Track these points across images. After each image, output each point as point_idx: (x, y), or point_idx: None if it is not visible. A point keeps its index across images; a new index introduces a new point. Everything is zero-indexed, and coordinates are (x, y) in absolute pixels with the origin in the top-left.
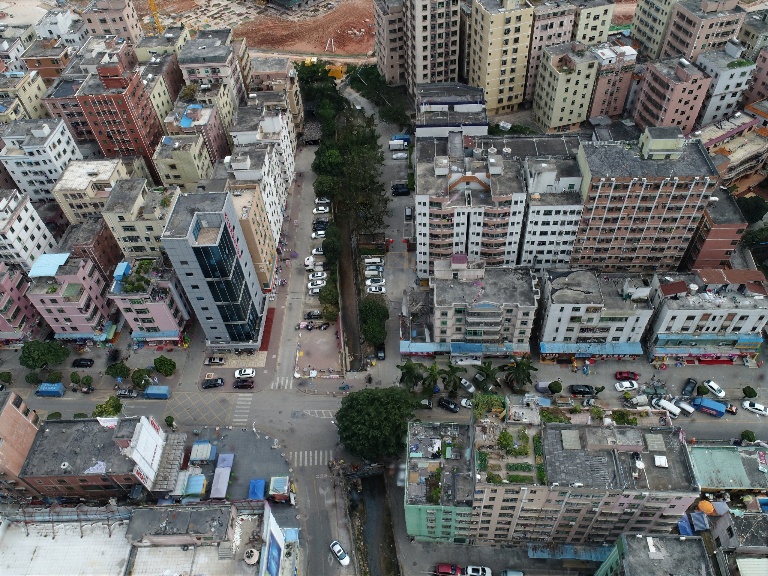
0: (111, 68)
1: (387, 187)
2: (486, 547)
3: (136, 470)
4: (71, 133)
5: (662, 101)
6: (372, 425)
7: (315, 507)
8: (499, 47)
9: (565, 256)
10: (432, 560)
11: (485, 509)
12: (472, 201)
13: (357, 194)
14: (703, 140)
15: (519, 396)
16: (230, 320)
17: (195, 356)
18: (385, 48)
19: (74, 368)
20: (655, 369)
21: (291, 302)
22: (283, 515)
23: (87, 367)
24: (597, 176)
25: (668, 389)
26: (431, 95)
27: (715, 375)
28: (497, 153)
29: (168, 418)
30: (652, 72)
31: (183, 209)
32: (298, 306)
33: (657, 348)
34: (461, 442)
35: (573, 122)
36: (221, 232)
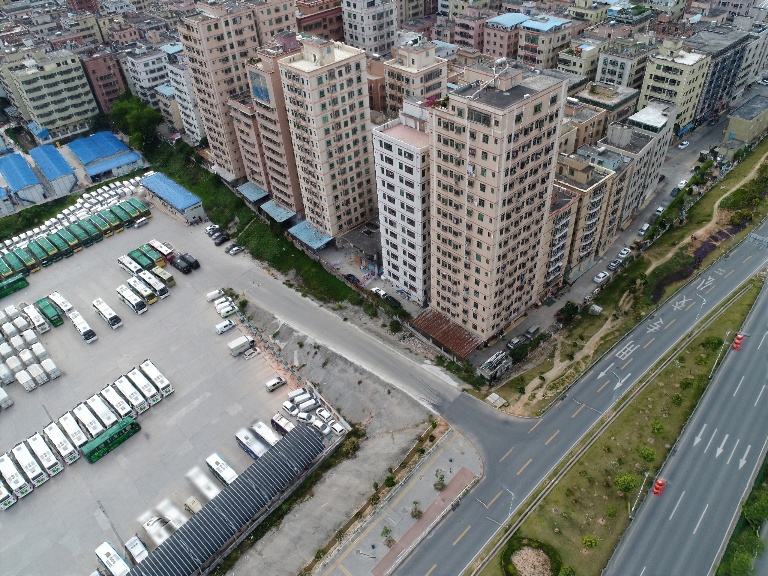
0: None
1: None
2: None
3: None
4: None
5: None
6: None
7: None
8: None
9: None
10: None
11: None
12: None
13: None
14: None
15: None
16: None
17: None
18: None
19: None
20: None
21: None
22: None
23: None
24: None
25: None
26: None
27: None
28: None
29: None
30: None
31: None
32: None
33: None
34: None
35: None
36: None
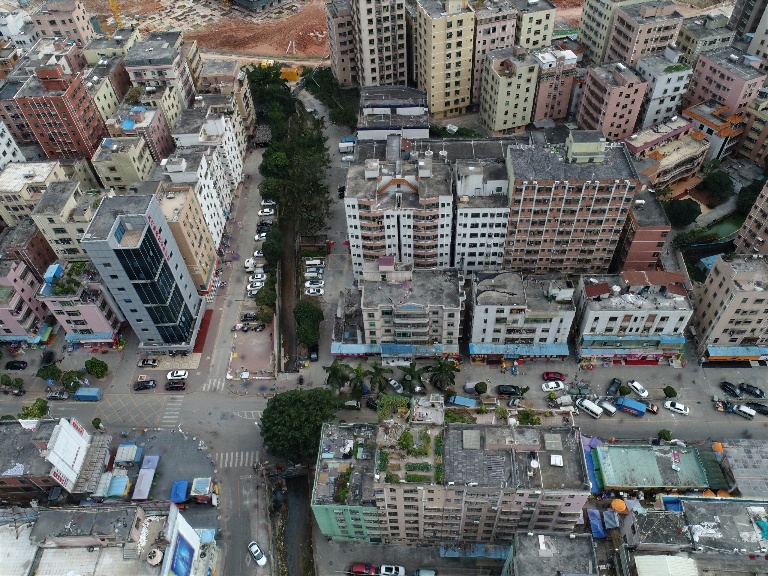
0: (50, 70)
1: (334, 189)
2: (402, 546)
3: (53, 472)
4: (17, 135)
5: (601, 105)
6: (293, 426)
7: (237, 508)
8: (442, 51)
9: (497, 258)
10: (348, 560)
11: (390, 508)
12: (402, 204)
13: (300, 196)
14: (639, 143)
15: (446, 397)
16: (161, 322)
17: (129, 358)
18: (336, 51)
19: (7, 370)
20: (582, 369)
21: (229, 304)
22: (204, 516)
23: (20, 369)
24: (521, 179)
25: (593, 389)
26: (375, 98)
27: (640, 375)
28: (434, 156)
29: (95, 420)
30: (591, 76)
31: (107, 212)
32: (236, 308)
33: (583, 349)
34: (373, 442)
35: (517, 125)
36: (144, 234)
